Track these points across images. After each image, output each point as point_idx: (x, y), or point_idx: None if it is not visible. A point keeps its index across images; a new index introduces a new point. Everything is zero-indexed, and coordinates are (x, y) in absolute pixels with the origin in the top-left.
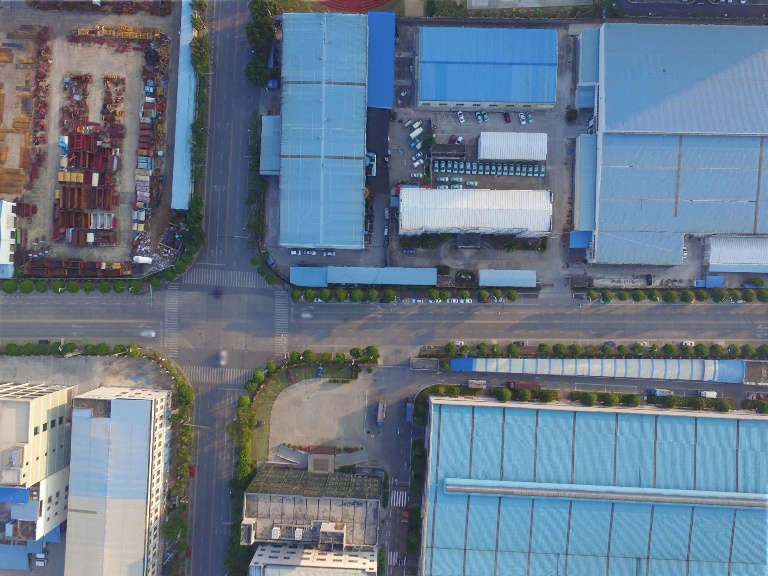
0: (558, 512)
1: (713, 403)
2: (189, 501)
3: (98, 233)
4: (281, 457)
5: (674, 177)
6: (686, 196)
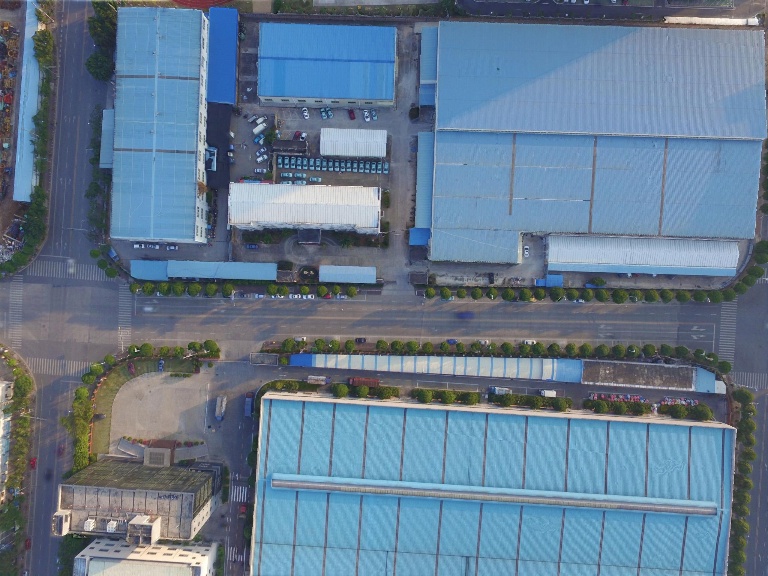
0: (387, 509)
1: (550, 402)
2: (30, 493)
3: None
4: (121, 450)
5: (508, 175)
6: (520, 194)
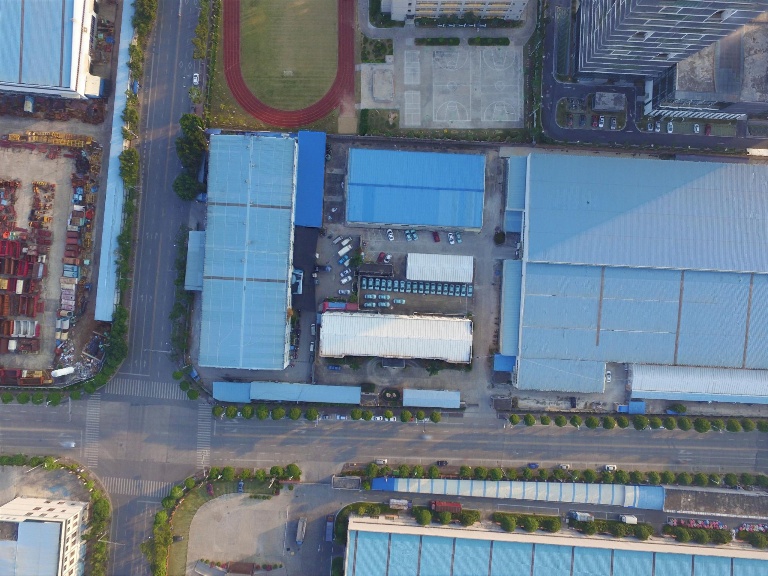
0: None
1: (632, 530)
2: None
3: (20, 340)
4: (198, 573)
5: (596, 307)
6: (608, 326)
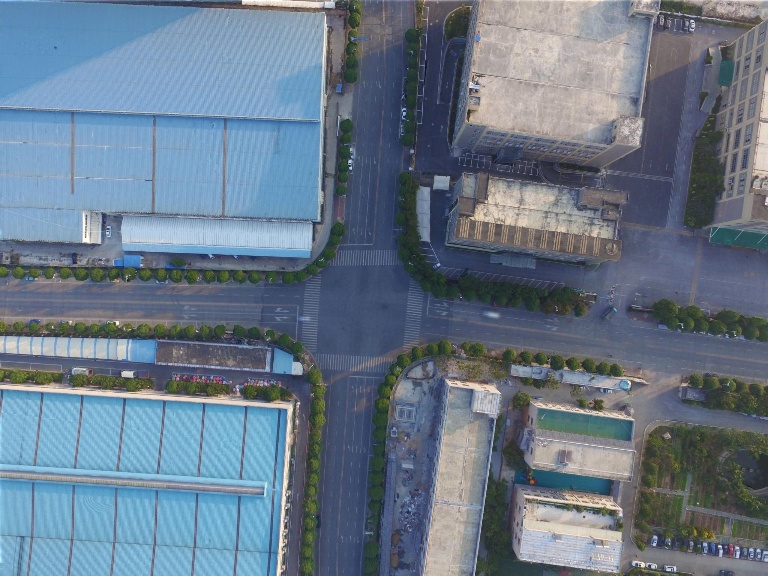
0: None
1: (122, 382)
2: None
3: None
4: None
5: (68, 154)
6: (81, 174)
